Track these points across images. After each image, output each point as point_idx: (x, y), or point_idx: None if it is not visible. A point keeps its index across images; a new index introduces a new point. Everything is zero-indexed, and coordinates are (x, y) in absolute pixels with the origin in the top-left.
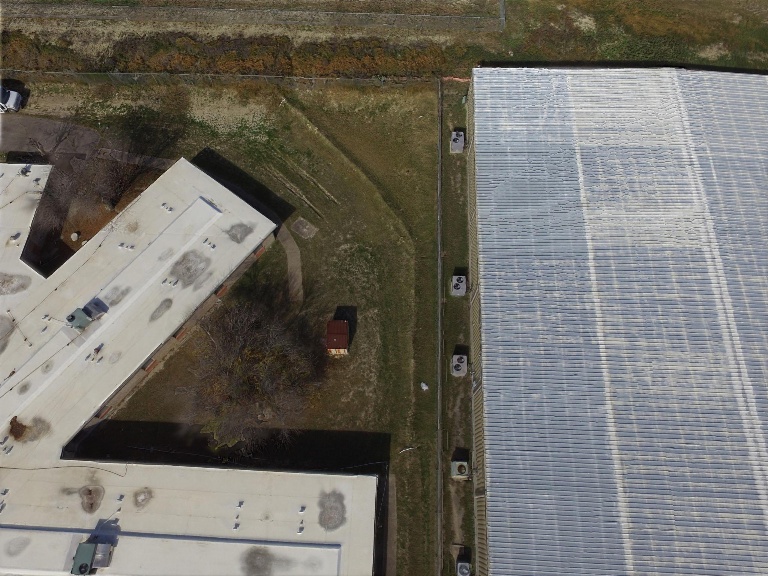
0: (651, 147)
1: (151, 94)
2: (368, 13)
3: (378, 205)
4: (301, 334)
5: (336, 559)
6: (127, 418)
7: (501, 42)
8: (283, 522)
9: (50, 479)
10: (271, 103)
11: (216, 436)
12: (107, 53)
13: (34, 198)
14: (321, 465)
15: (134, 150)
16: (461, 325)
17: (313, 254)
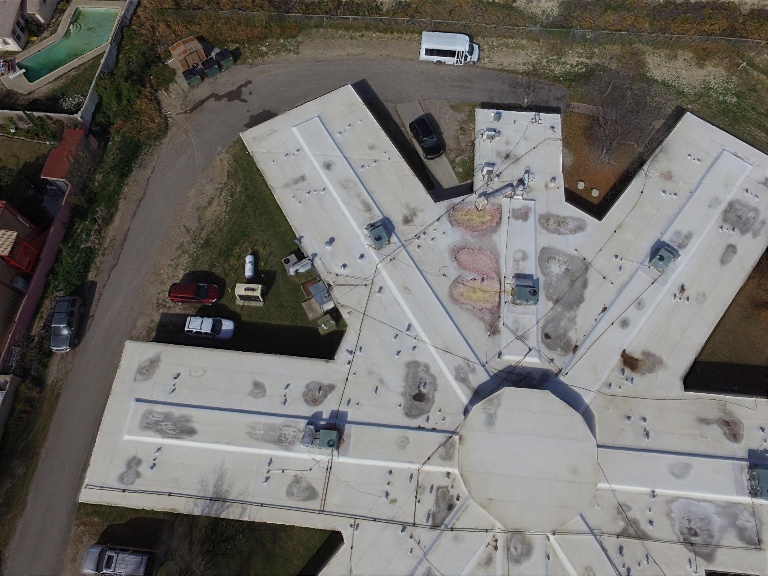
0: None
1: (604, 53)
2: None
3: None
4: None
5: None
6: (699, 359)
7: None
8: None
9: (684, 410)
10: (728, 66)
11: None
12: (552, 12)
13: (556, 145)
14: None
15: (606, 105)
16: None
17: None
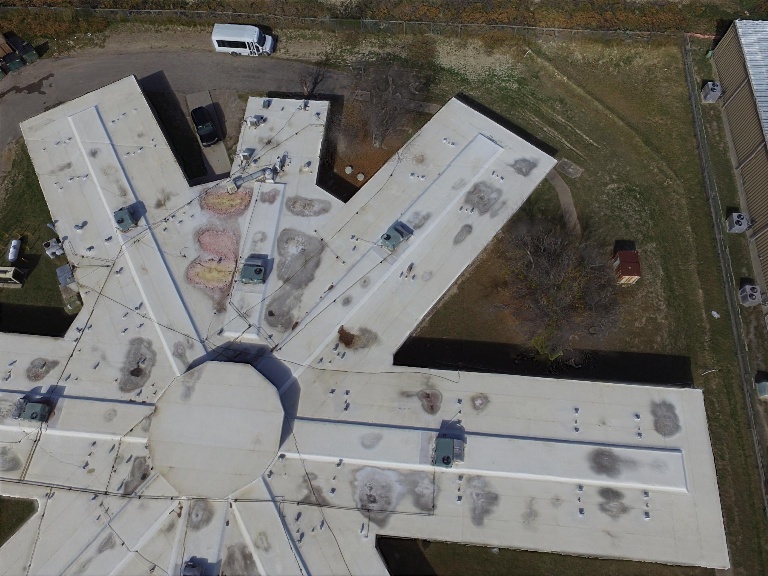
0: None
1: (397, 42)
2: None
3: (639, 149)
4: None
5: (681, 462)
6: (431, 335)
7: (735, 2)
8: (621, 428)
9: (387, 382)
10: (516, 54)
11: (542, 348)
12: (351, 3)
13: (318, 130)
14: None
15: None
16: (743, 260)
17: (583, 192)
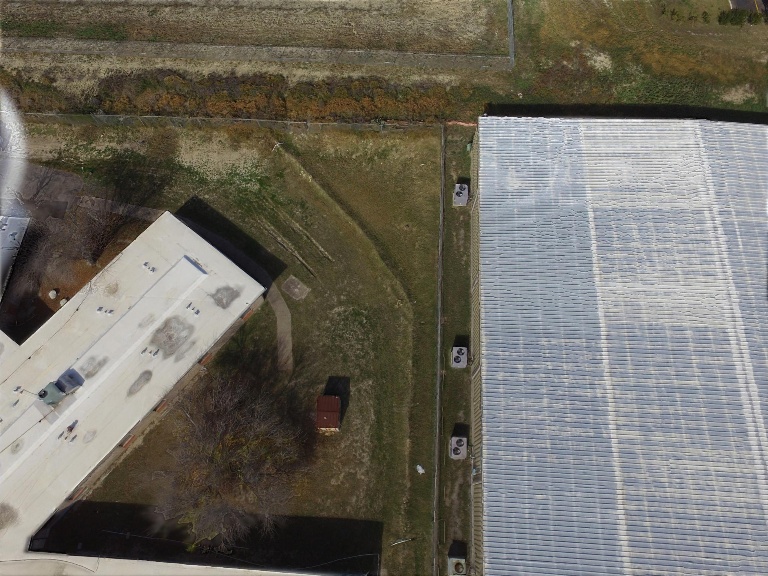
0: (671, 210)
1: (137, 136)
2: (368, 50)
3: (375, 263)
4: (290, 407)
5: None
6: (103, 499)
7: (510, 82)
8: None
9: (17, 573)
10: (263, 147)
11: (194, 529)
12: (92, 91)
13: (10, 255)
14: (308, 558)
15: (118, 198)
16: (461, 401)
17: (304, 317)
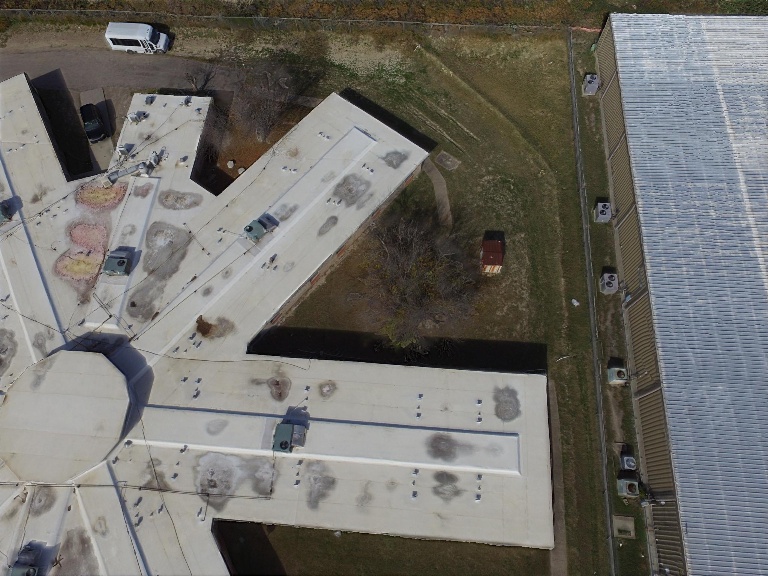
0: None
1: (290, 39)
2: None
3: (517, 141)
4: (453, 254)
5: (516, 445)
6: (295, 325)
7: None
8: (462, 413)
9: (239, 370)
10: (406, 49)
11: (392, 336)
12: (247, 1)
13: (197, 125)
14: None
15: (279, 89)
16: (606, 249)
17: (458, 184)
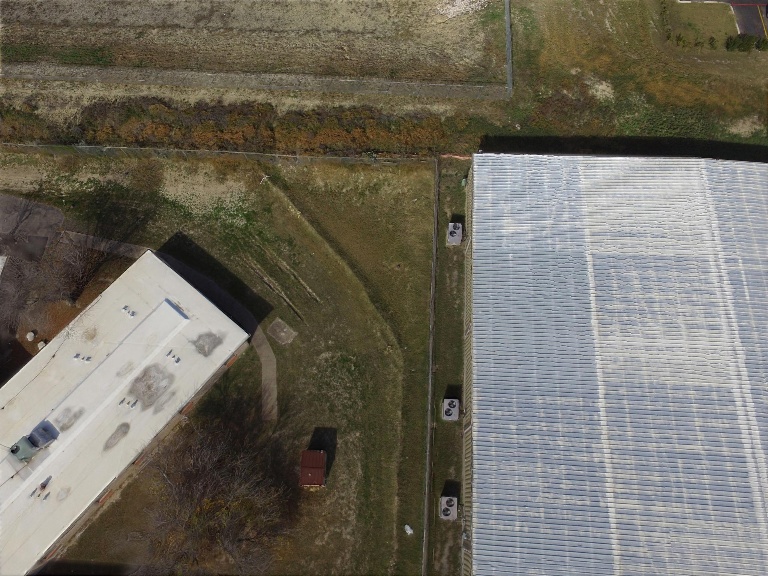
0: (674, 258)
1: (121, 167)
2: (360, 78)
3: (364, 306)
4: (273, 460)
5: None
6: (78, 557)
7: (507, 113)
8: None
9: None
10: (251, 180)
11: None
12: (75, 120)
13: None
14: None
15: (100, 233)
16: (452, 456)
17: (290, 363)
